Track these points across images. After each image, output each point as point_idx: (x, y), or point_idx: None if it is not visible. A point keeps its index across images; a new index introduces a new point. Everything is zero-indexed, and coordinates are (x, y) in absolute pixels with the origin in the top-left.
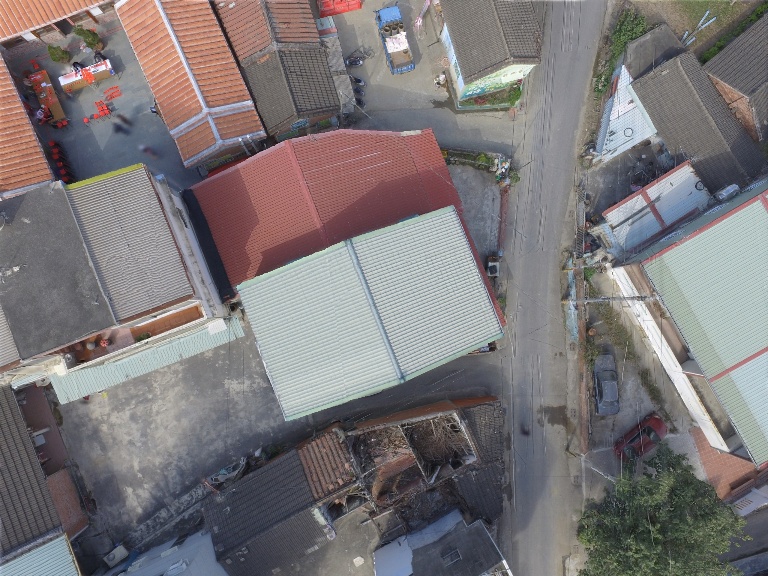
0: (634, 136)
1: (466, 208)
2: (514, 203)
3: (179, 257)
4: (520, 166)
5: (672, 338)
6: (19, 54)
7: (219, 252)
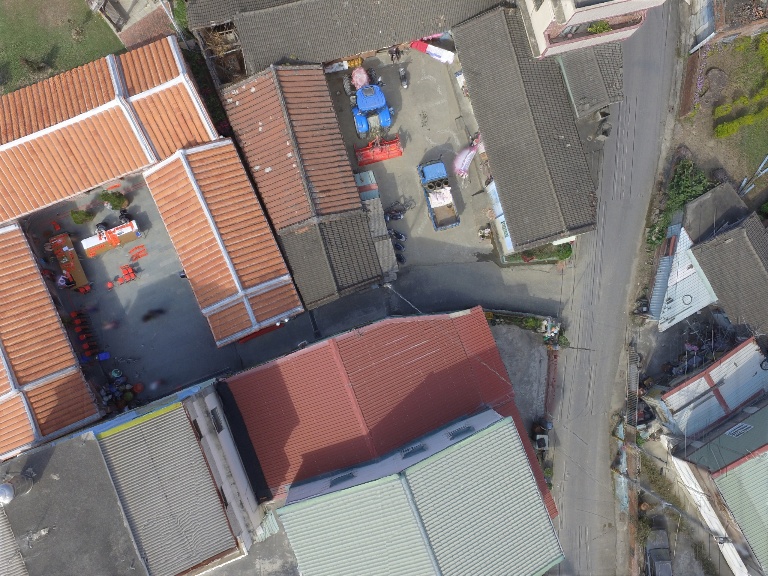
0: (693, 304)
1: (512, 371)
2: (562, 364)
3: (221, 506)
4: (568, 324)
5: (740, 546)
6: (39, 213)
7: (256, 450)
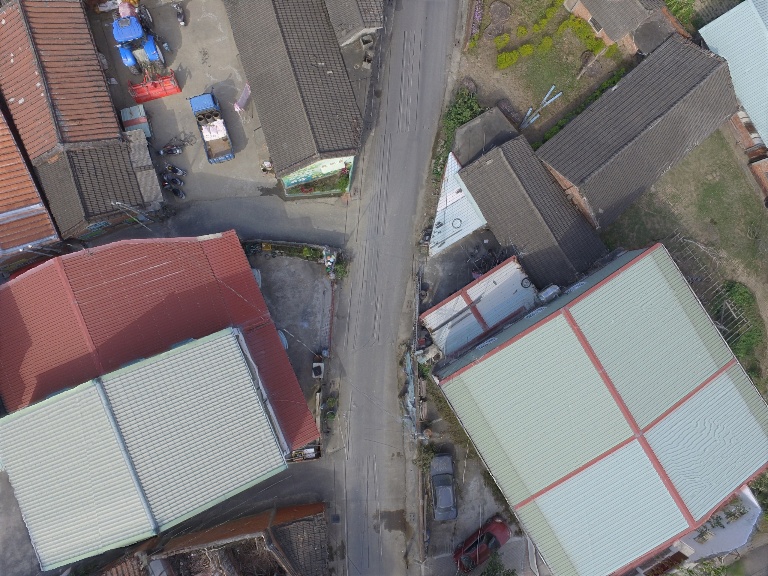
0: (463, 227)
1: (294, 302)
2: (347, 295)
3: None
4: (353, 255)
5: None
6: None
7: None
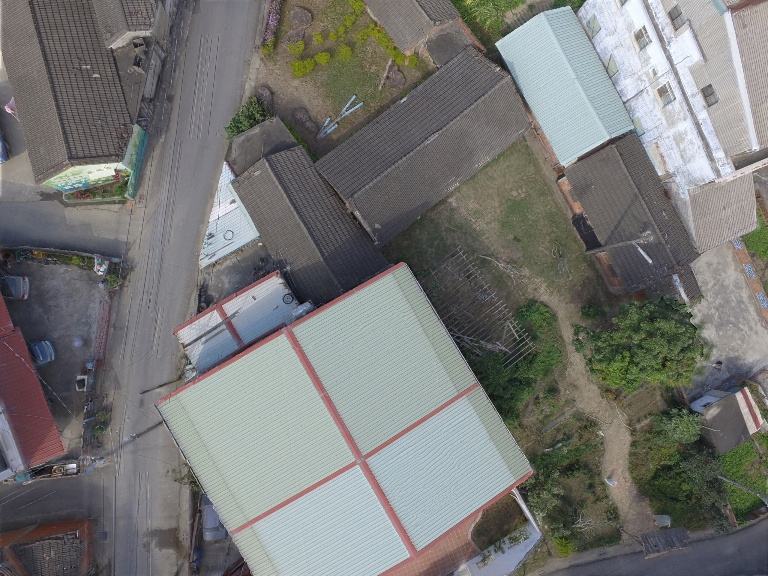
0: (235, 239)
1: (68, 312)
2: (126, 305)
3: None
4: (135, 265)
5: None
6: None
7: None
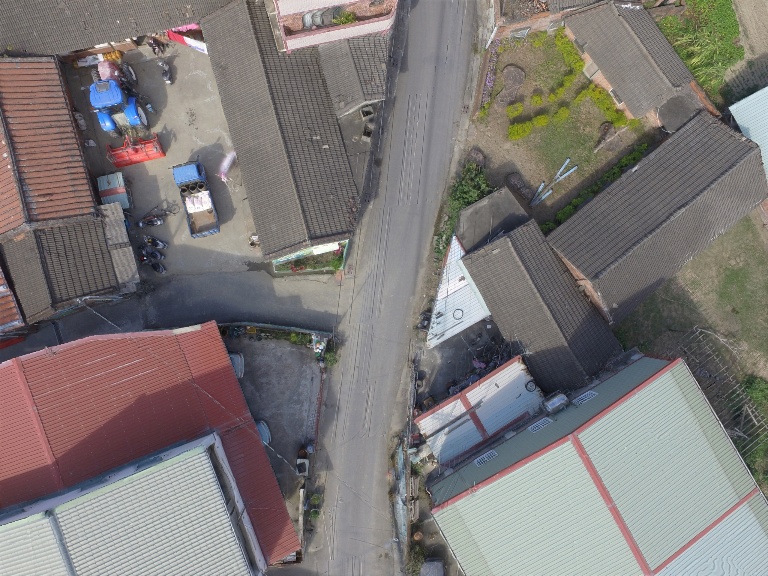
0: (465, 318)
1: (280, 389)
2: (337, 381)
3: None
4: (346, 339)
5: None
6: None
7: None
